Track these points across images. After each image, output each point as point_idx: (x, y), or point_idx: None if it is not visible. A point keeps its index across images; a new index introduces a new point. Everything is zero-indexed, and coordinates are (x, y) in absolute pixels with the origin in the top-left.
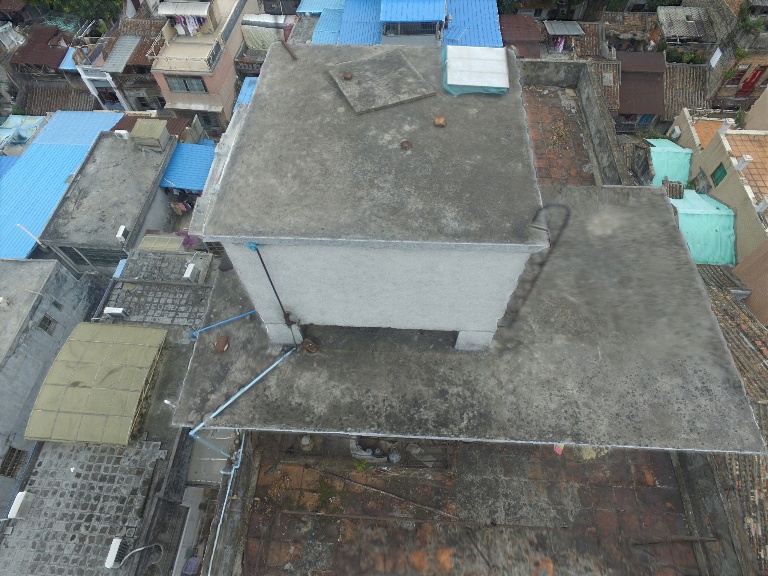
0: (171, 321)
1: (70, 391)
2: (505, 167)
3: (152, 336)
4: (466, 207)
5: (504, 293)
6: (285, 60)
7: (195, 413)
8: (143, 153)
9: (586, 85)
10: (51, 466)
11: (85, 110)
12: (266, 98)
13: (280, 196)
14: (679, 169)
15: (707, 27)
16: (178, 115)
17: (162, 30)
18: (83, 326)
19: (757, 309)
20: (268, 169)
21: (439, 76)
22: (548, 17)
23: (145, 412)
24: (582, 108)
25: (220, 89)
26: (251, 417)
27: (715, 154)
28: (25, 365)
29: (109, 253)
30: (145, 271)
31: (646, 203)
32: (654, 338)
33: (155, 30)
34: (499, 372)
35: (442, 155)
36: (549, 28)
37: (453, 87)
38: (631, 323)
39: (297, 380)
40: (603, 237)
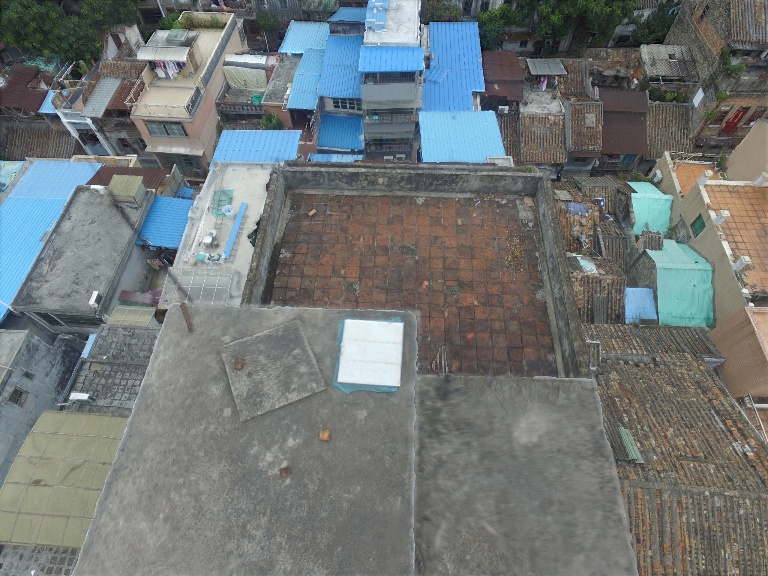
0: None
1: (31, 490)
2: (383, 504)
3: (117, 426)
4: (336, 567)
5: None
6: (181, 332)
7: None
8: (119, 209)
9: (542, 200)
10: (11, 569)
11: (66, 152)
12: (153, 392)
13: (148, 549)
14: (660, 216)
15: (690, 66)
16: (159, 158)
17: (142, 75)
18: (48, 415)
19: (731, 378)
20: (141, 506)
21: (334, 359)
22: (534, 48)
23: None
24: (539, 222)
25: (201, 133)
26: None
27: (694, 205)
28: None
29: (83, 316)
30: (114, 348)
31: (575, 401)
32: None
33: (135, 72)
34: None
35: (321, 485)
36: (532, 67)
37: (343, 384)
38: (548, 561)
39: None
40: (528, 446)
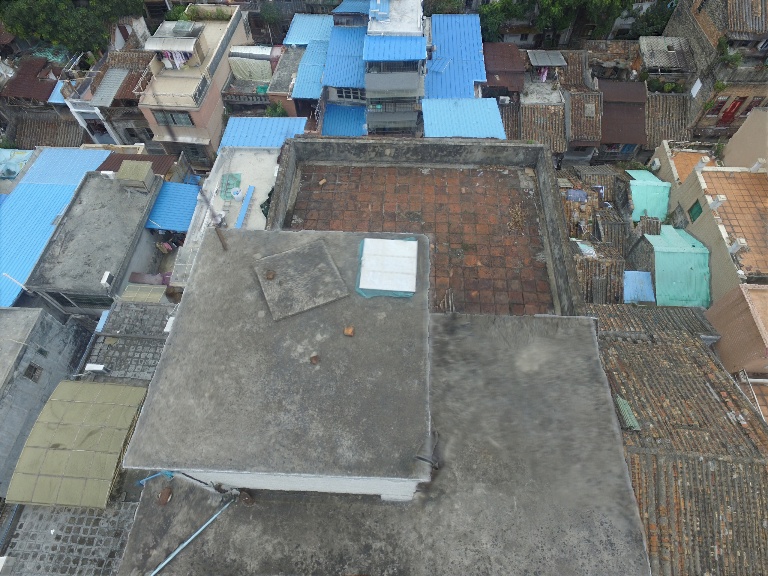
0: (151, 377)
1: (50, 454)
2: (402, 385)
3: (131, 395)
4: (361, 434)
5: (409, 485)
6: (216, 250)
7: (137, 570)
8: (129, 194)
9: (543, 169)
10: (32, 528)
11: (74, 142)
12: (194, 299)
13: (196, 420)
14: (658, 202)
15: (688, 57)
16: (166, 147)
17: (149, 65)
18: (64, 385)
19: (726, 355)
20: (188, 387)
21: (355, 272)
22: (534, 41)
23: (124, 471)
24: (539, 190)
25: (207, 122)
26: (188, 575)
27: (692, 190)
28: (10, 415)
29: (94, 297)
30: (127, 324)
31: (573, 335)
32: (567, 487)
33: (143, 63)
34: (420, 525)
35: (347, 371)
36: (532, 59)
37: (365, 290)
38: (547, 470)
39: (233, 534)
40: (530, 374)
